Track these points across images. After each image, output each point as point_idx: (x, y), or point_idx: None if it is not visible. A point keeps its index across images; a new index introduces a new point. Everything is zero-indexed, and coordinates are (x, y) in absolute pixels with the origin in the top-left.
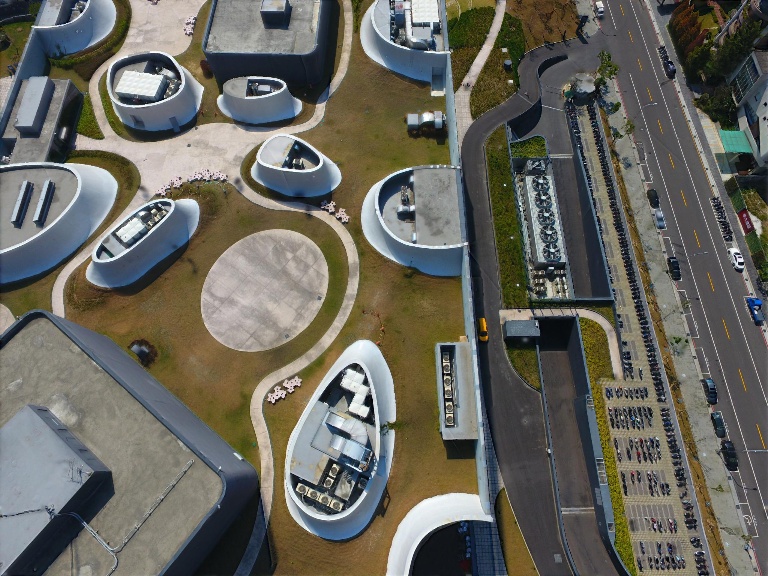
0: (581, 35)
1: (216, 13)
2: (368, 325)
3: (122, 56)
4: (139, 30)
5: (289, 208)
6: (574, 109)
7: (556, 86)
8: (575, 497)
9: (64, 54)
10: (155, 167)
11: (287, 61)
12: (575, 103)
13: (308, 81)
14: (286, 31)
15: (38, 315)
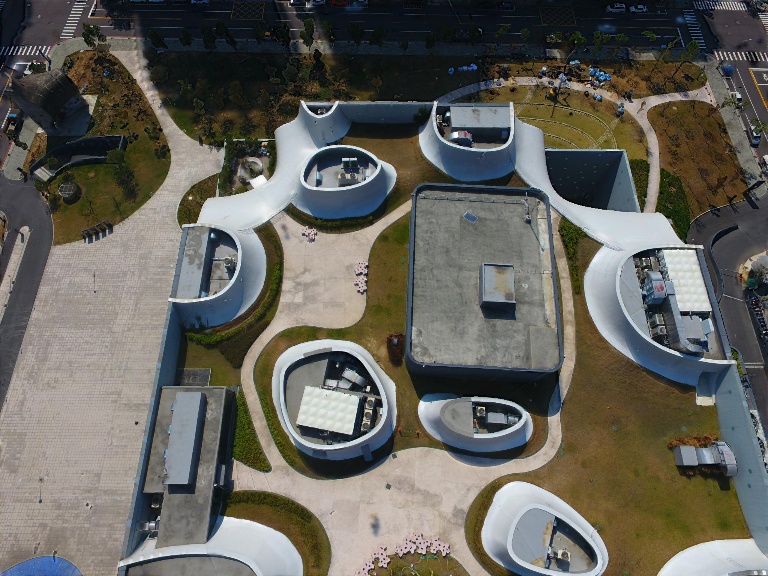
0: (749, 197)
1: (415, 290)
2: None
3: (279, 327)
4: (296, 283)
5: None
6: (758, 301)
7: (730, 266)
8: None
9: (205, 327)
10: (347, 525)
11: (521, 373)
12: (756, 291)
13: (533, 380)
14: (513, 323)
15: None
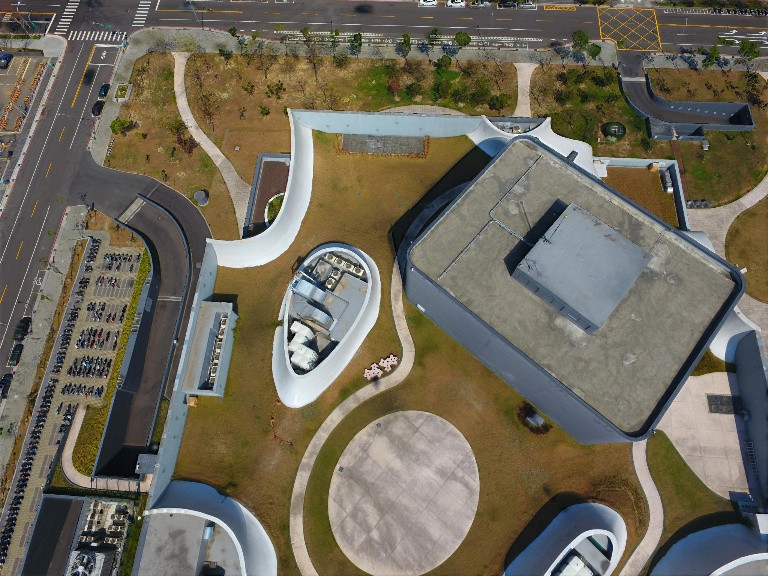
0: None
1: None
2: (287, 426)
3: None
4: None
5: None
6: None
7: None
8: (170, 308)
9: None
10: None
11: None
12: None
13: None
14: None
15: (634, 436)
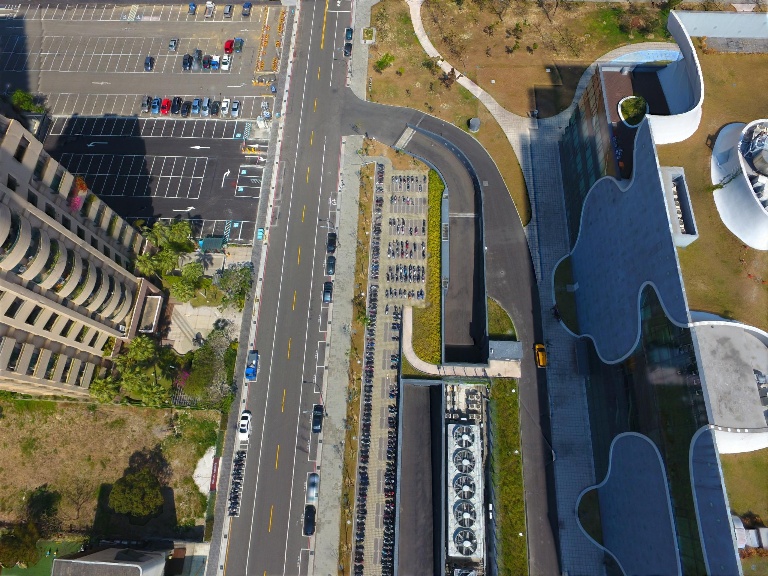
0: None
1: None
2: (758, 266)
3: None
4: None
5: None
6: None
7: None
8: (461, 224)
9: None
10: None
11: None
12: None
13: None
14: None
15: None
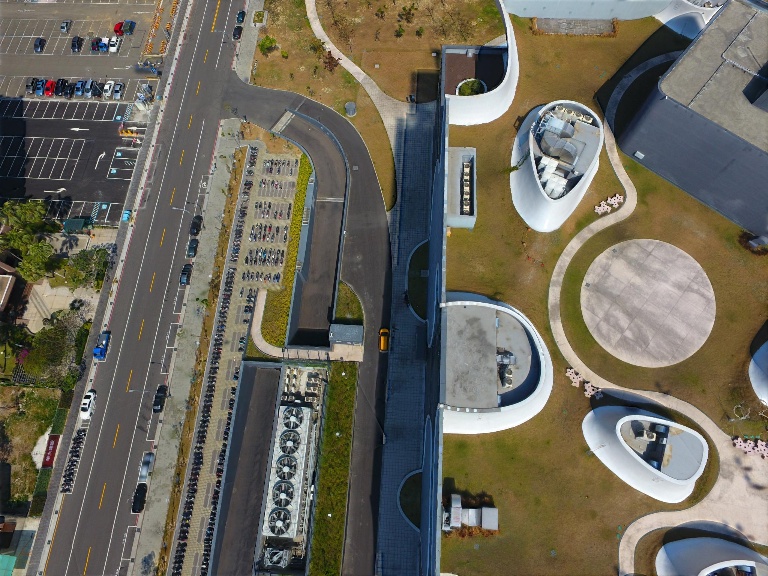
0: None
1: None
2: (539, 248)
3: None
4: None
5: (641, 394)
6: None
7: None
8: (329, 208)
9: None
10: None
11: None
12: None
13: None
14: None
15: None
